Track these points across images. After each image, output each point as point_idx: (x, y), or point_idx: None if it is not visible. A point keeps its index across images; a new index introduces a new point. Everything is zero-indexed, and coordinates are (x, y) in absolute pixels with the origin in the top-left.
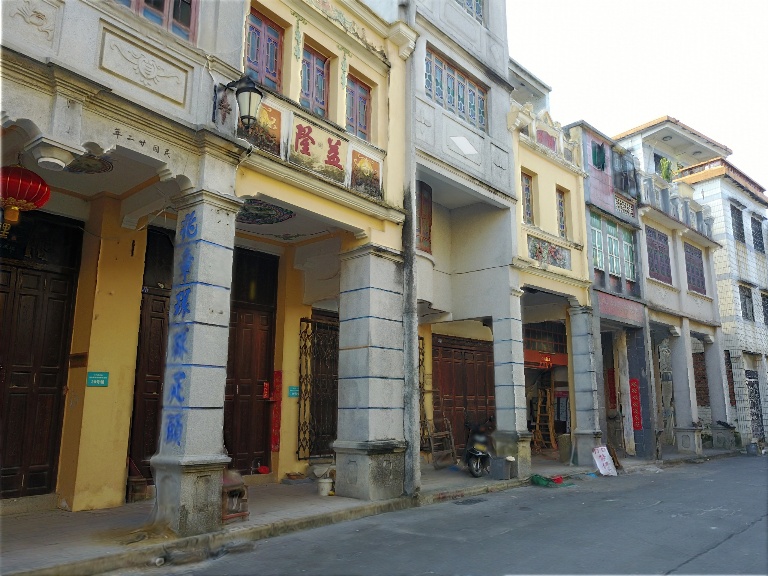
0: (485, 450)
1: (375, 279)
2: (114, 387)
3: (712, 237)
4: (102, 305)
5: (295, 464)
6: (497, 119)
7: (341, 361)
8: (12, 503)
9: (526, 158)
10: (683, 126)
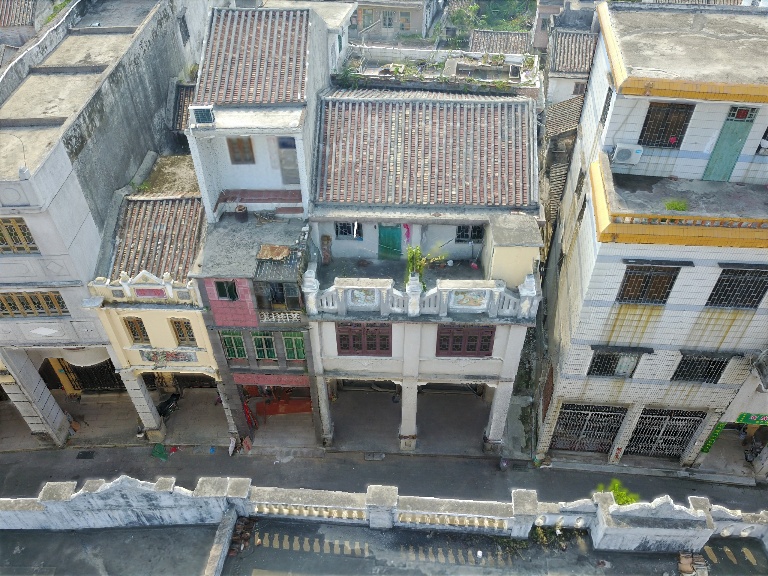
0: None
1: (8, 391)
2: None
3: (521, 312)
4: None
5: (74, 390)
6: (73, 306)
7: None
8: None
9: None
10: (674, 94)
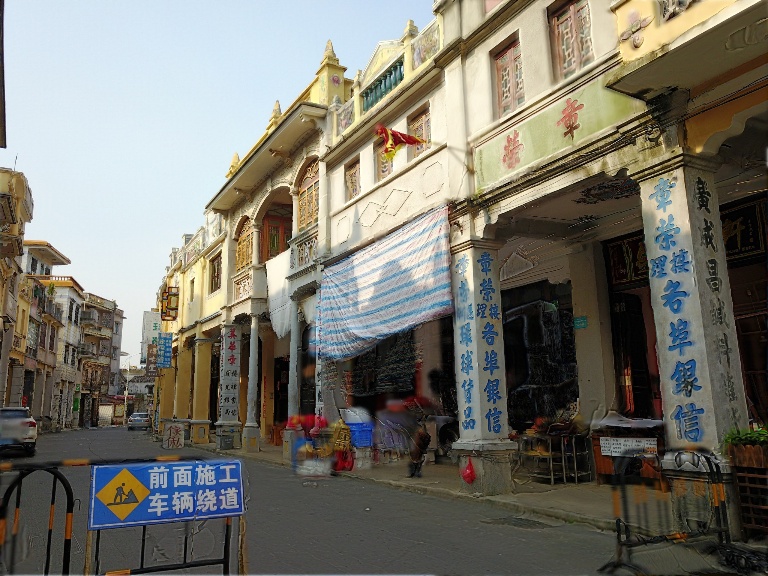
0: None
1: None
2: None
3: (61, 321)
4: None
5: None
6: None
7: None
8: None
9: (18, 300)
10: (53, 248)
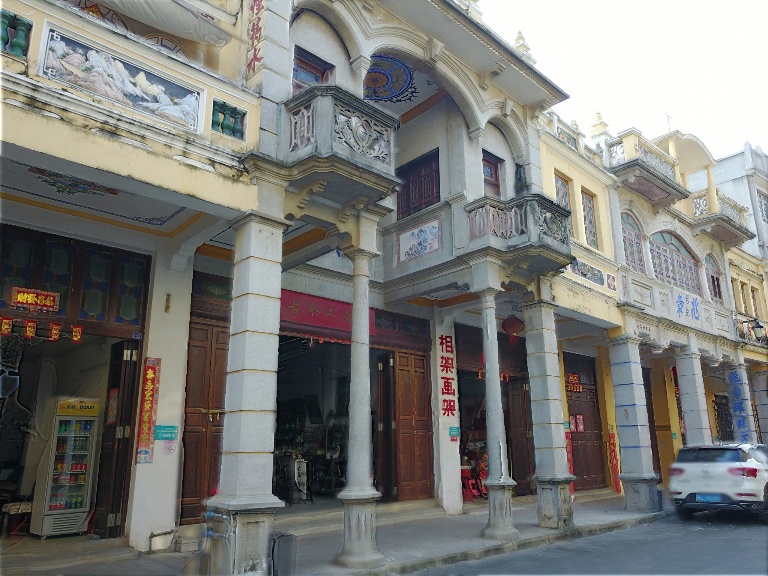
0: None
1: None
2: (678, 439)
3: None
4: (670, 404)
5: None
6: None
7: (761, 424)
8: (658, 486)
9: None
10: None
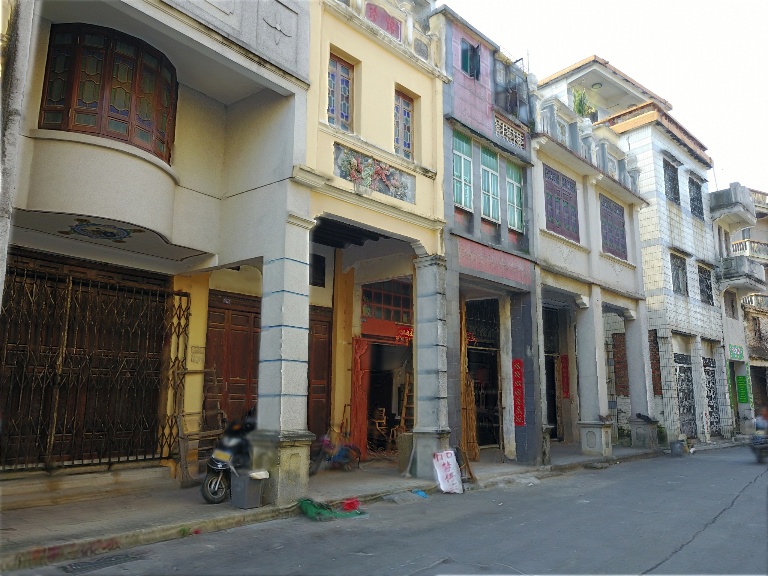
0: (231, 460)
1: None
2: None
3: (637, 192)
4: None
5: None
6: None
7: None
8: None
9: (340, 34)
10: (614, 70)
